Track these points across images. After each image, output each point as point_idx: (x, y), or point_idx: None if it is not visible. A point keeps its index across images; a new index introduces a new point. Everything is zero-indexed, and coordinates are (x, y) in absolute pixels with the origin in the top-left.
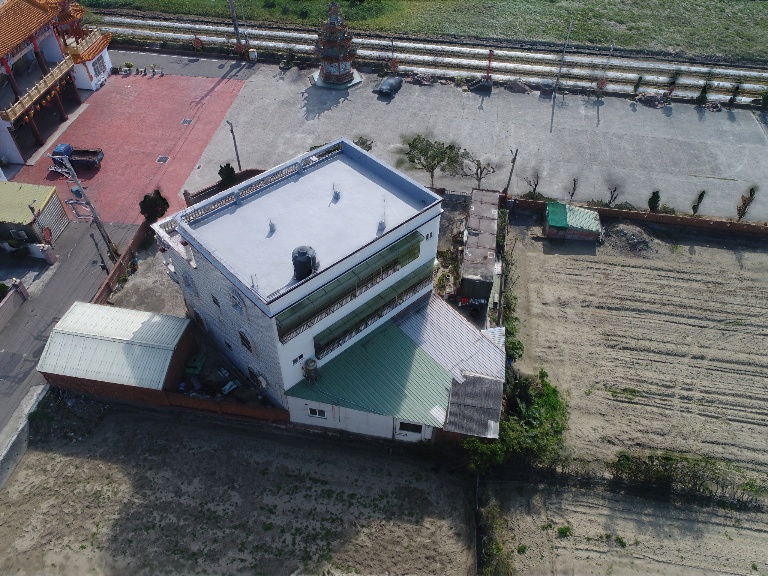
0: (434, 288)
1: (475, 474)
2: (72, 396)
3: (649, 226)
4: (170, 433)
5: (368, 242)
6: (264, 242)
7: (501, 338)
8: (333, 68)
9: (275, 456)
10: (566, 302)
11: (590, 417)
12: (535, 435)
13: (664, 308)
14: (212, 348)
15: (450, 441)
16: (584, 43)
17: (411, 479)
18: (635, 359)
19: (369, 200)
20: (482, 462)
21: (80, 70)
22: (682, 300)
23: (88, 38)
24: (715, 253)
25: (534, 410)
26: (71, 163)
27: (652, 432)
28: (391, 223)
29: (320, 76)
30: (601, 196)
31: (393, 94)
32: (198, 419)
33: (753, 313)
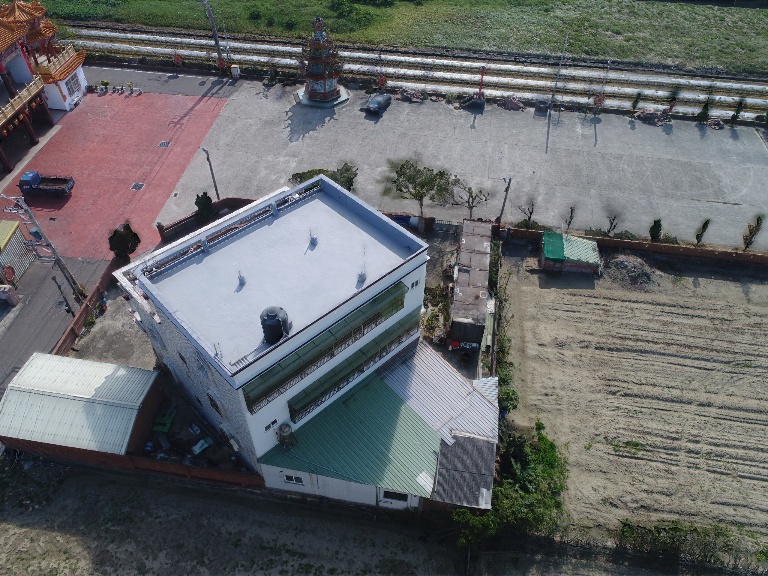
0: (423, 329)
1: (466, 546)
2: (29, 458)
3: (650, 256)
4: (135, 499)
5: (346, 299)
6: (232, 297)
7: (494, 390)
8: (318, 85)
9: (249, 525)
10: (563, 343)
11: (590, 475)
12: (531, 503)
13: (668, 348)
14: (183, 401)
15: (439, 510)
16: (580, 55)
17: (397, 550)
18: (638, 407)
19: (349, 246)
20: (473, 536)
21: (52, 90)
22: (687, 339)
23: (60, 56)
24: (721, 286)
25: (530, 470)
26: (40, 192)
27: (657, 492)
28: (372, 273)
29: (305, 93)
30: (599, 223)
31: (381, 112)
32: (166, 482)
33: (762, 353)
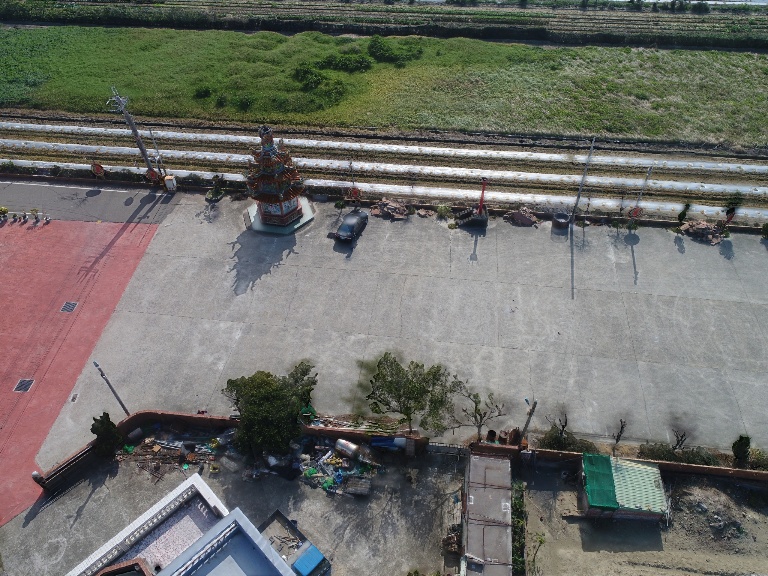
0: None
1: None
2: None
3: (736, 484)
4: None
5: None
6: None
7: None
8: (273, 207)
9: None
10: None
11: None
12: None
13: None
14: None
15: None
16: (600, 133)
17: None
18: None
19: None
20: None
21: None
22: None
23: None
24: None
25: None
26: None
27: None
28: None
29: (258, 213)
30: (657, 425)
31: (355, 239)
32: None
33: None
